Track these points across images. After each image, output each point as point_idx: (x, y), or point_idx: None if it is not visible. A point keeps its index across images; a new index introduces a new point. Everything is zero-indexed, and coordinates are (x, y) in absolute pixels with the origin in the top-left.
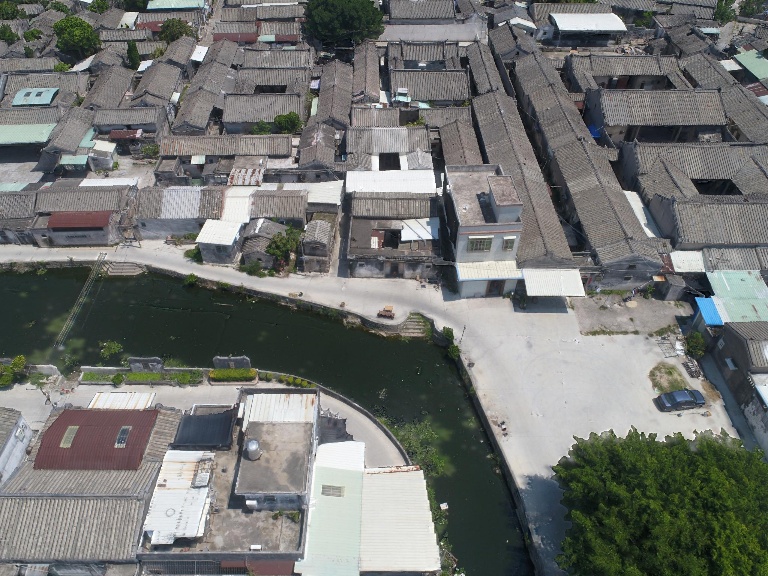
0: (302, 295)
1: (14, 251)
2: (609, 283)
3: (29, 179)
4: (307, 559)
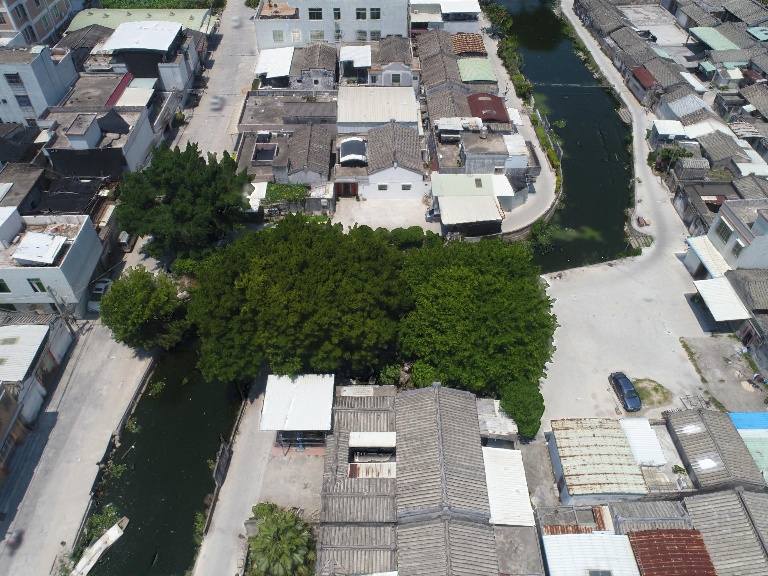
0: (640, 183)
1: (615, 76)
2: (761, 360)
3: (684, 64)
4: (439, 175)
